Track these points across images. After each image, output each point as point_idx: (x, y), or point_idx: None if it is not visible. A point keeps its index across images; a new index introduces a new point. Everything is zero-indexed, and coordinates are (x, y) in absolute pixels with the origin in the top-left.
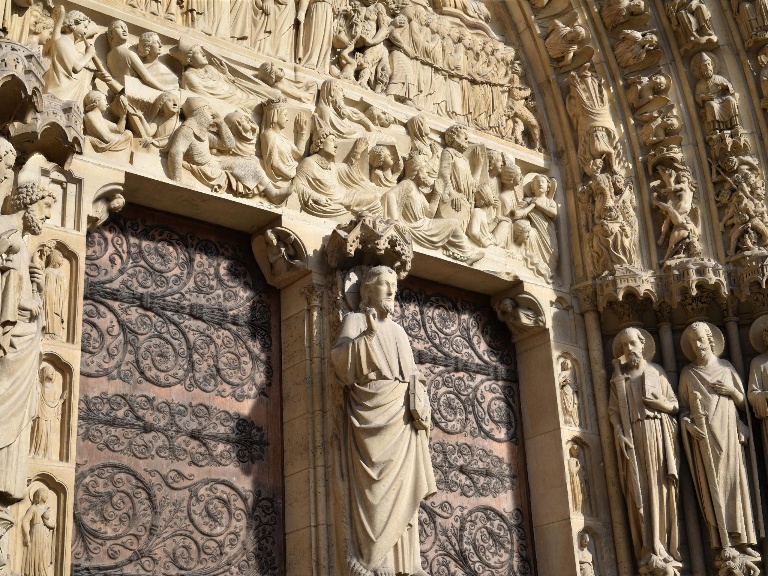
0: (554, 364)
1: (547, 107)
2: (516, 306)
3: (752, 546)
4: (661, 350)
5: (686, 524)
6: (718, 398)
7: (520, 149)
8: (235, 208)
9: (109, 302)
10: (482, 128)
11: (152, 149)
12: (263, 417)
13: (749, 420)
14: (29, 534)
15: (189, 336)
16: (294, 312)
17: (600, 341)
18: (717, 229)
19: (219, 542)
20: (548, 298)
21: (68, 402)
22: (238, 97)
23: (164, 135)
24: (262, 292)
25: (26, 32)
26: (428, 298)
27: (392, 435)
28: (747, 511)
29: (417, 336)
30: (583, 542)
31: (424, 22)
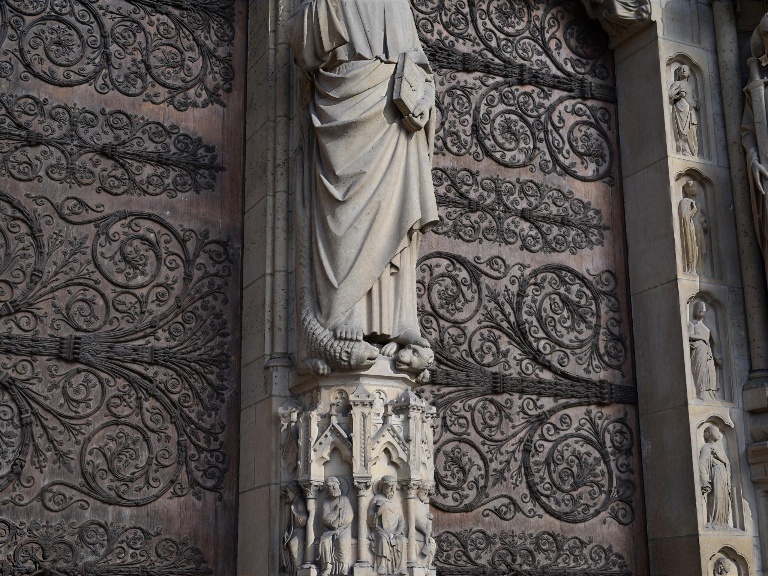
0: (662, 69)
1: None
2: None
3: None
4: None
5: None
6: None
7: None
8: None
9: None
10: None
11: None
12: (216, 133)
13: None
14: None
15: (105, 20)
16: None
17: (734, 38)
18: None
19: (139, 296)
20: None
21: None
22: None
23: None
24: None
25: None
26: None
27: (366, 137)
28: None
29: (462, 35)
30: (697, 312)
31: None
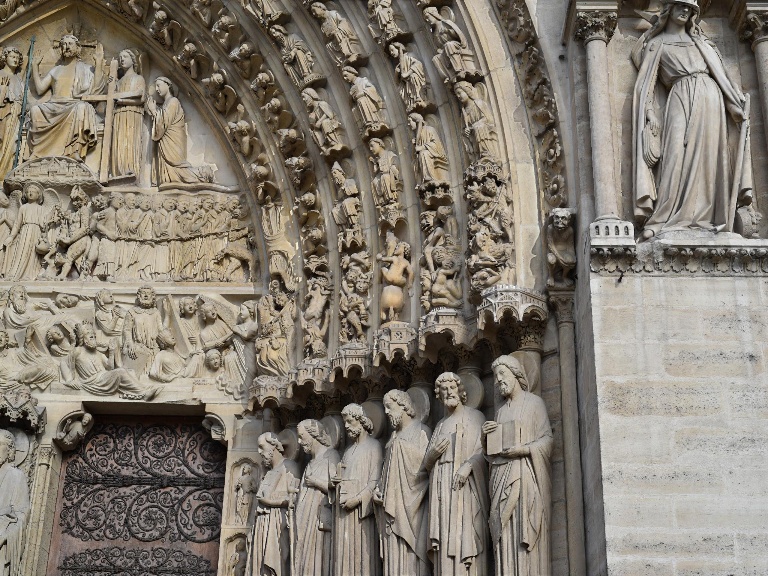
0: (227, 472)
1: None
2: (212, 424)
3: None
4: None
5: None
6: (307, 490)
7: (226, 285)
8: None
9: None
10: (184, 278)
11: None
12: None
13: (332, 507)
14: None
15: None
16: None
17: None
18: (340, 326)
19: None
20: (233, 413)
21: None
22: None
23: None
24: None
25: None
26: (144, 430)
27: None
28: None
29: (127, 464)
30: None
31: (132, 206)
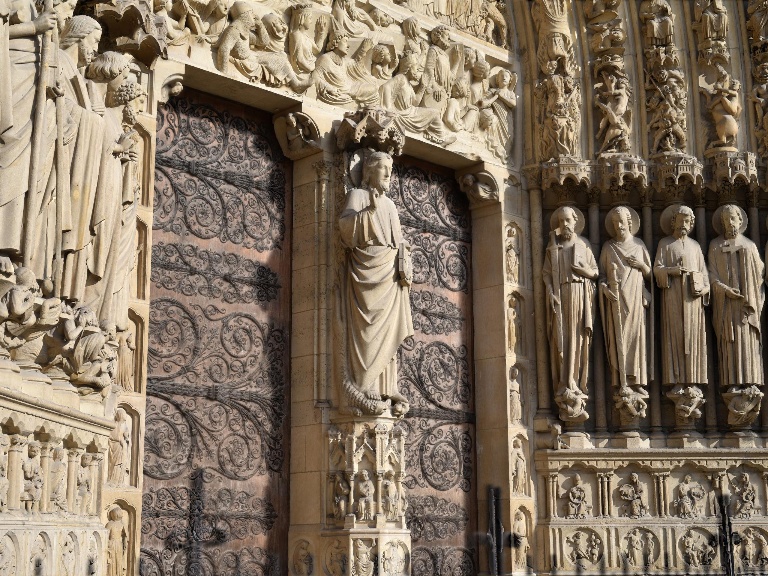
0: (503, 232)
1: (515, 9)
2: (476, 181)
3: (643, 386)
4: (589, 225)
5: (594, 366)
6: (630, 270)
7: (490, 46)
8: (266, 95)
9: (165, 168)
10: (461, 27)
11: (205, 44)
12: (277, 265)
13: (652, 288)
14: (117, 353)
15: (224, 198)
16: (306, 182)
17: (541, 214)
18: (645, 130)
19: (243, 362)
20: (503, 176)
21: (144, 253)
22: (273, 0)
23: (215, 33)
24: (279, 162)
25: None
26: (406, 170)
27: (384, 290)
28: (643, 360)
29: (396, 202)
30: (514, 375)
31: None
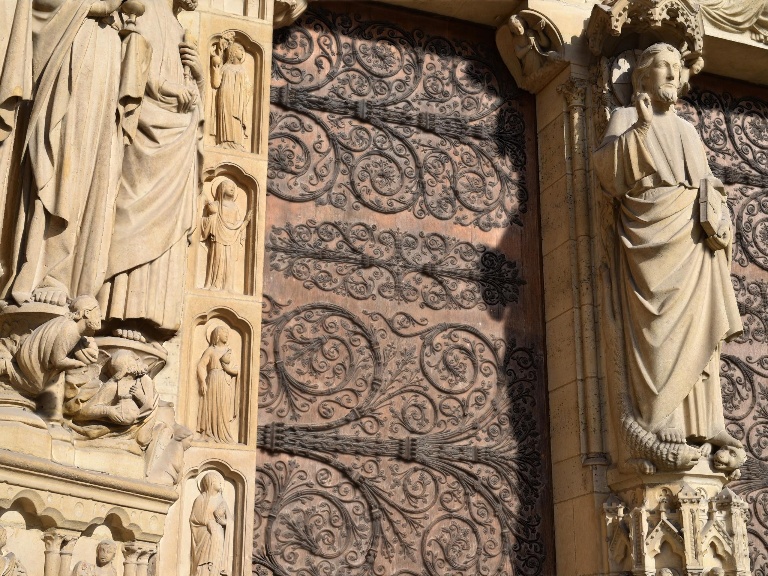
0: None
1: None
2: None
3: None
4: None
5: None
6: None
7: None
8: None
9: (315, 113)
10: None
11: None
12: (516, 250)
13: None
14: (205, 381)
15: (418, 153)
16: (551, 118)
17: None
18: None
19: (461, 401)
20: None
21: (253, 224)
22: None
23: None
24: (512, 98)
25: None
26: (736, 102)
27: (676, 257)
28: None
29: (722, 150)
30: None
31: None
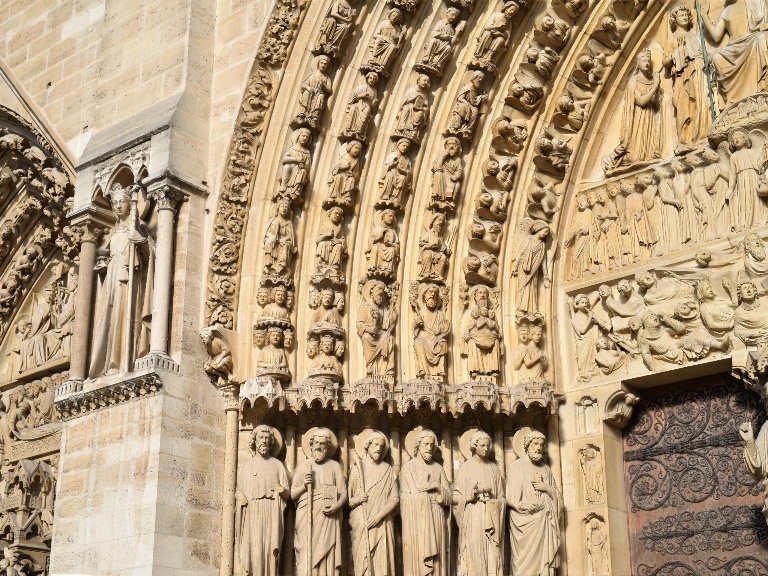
0: None
1: None
2: None
3: None
4: None
5: None
6: None
7: None
8: (705, 366)
9: (658, 457)
10: None
11: (637, 357)
12: None
13: None
14: None
15: (713, 461)
16: None
17: None
18: None
19: None
20: None
21: None
22: (683, 290)
23: None
24: None
25: (495, 360)
26: None
27: None
28: None
29: None
30: None
31: None
